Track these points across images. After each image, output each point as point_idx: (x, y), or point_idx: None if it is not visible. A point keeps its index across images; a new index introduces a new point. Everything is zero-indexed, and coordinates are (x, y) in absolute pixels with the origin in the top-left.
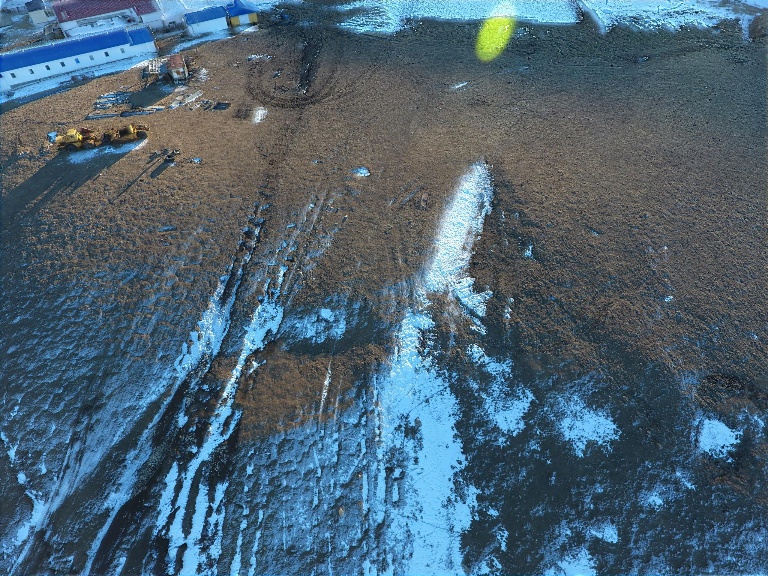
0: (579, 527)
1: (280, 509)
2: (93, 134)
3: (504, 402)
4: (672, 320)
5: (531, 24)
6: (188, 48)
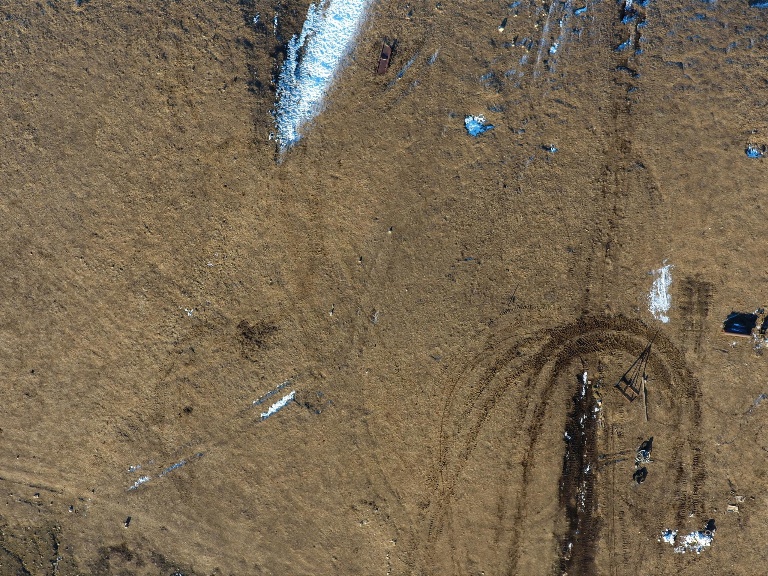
0: None
1: None
2: None
3: None
4: None
5: None
6: None
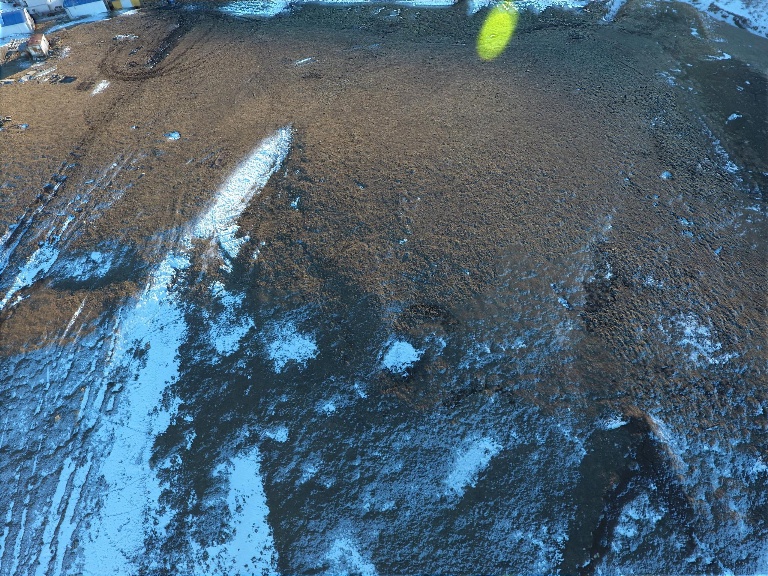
0: (257, 430)
1: (4, 416)
2: None
3: (227, 328)
4: (399, 259)
5: (406, 7)
6: (61, 29)
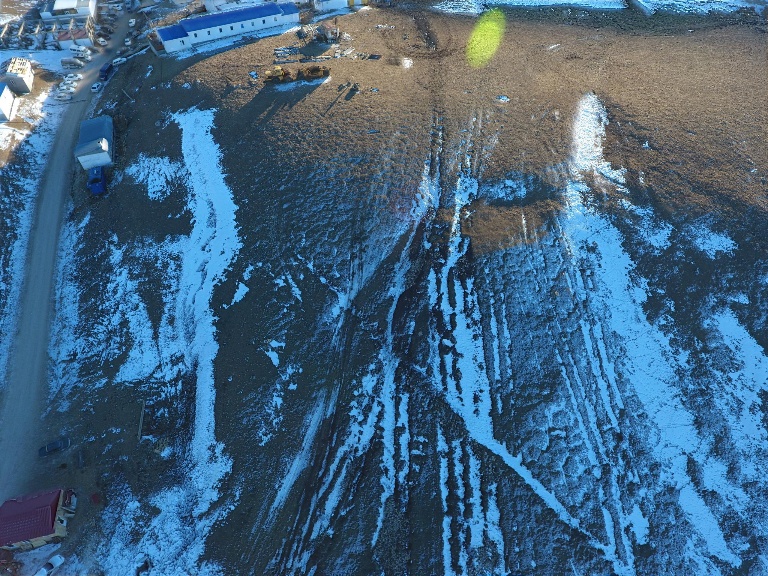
0: (722, 296)
1: (515, 292)
2: (290, 71)
3: (653, 231)
4: (759, 182)
5: (588, 9)
6: (324, 19)
